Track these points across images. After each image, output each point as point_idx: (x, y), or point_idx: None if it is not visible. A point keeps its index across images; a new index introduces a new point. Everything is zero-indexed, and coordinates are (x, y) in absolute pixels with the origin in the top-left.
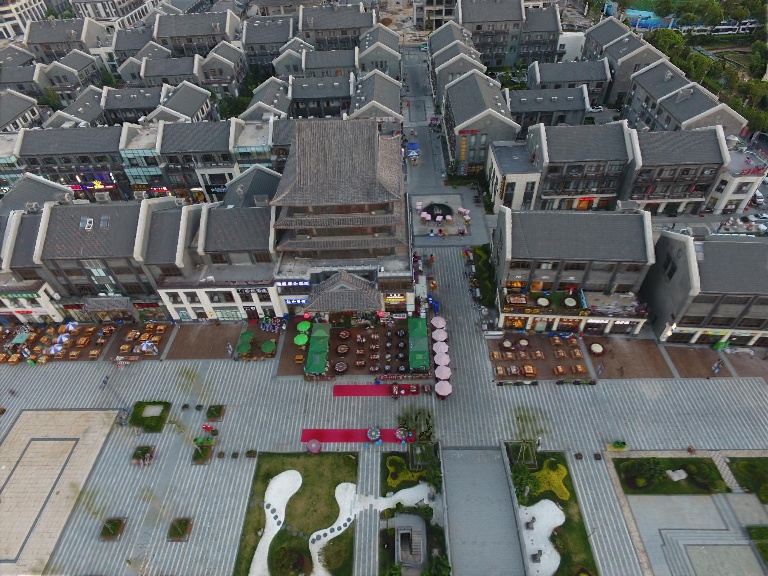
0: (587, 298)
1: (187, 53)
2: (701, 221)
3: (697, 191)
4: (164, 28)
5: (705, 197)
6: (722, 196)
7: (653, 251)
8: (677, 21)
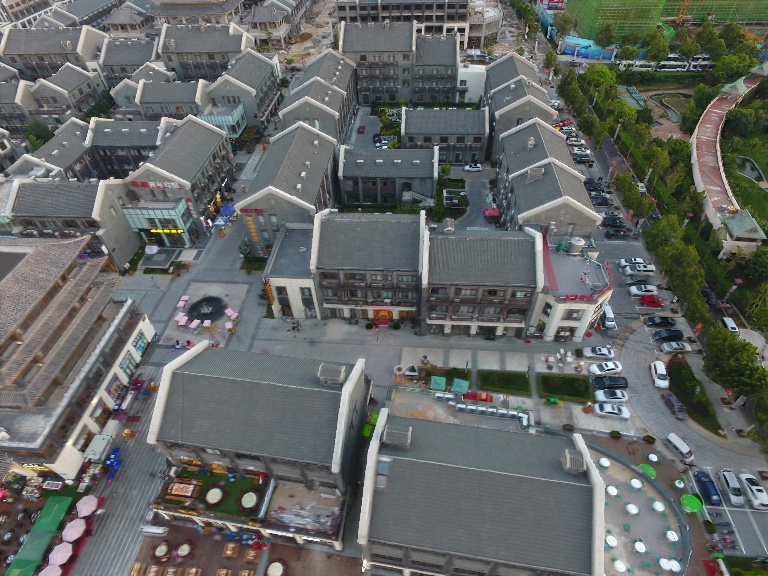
0: (280, 492)
1: (41, 72)
2: (523, 350)
3: (515, 314)
4: (12, 44)
5: (525, 322)
6: (549, 321)
7: (339, 454)
8: (616, 54)
